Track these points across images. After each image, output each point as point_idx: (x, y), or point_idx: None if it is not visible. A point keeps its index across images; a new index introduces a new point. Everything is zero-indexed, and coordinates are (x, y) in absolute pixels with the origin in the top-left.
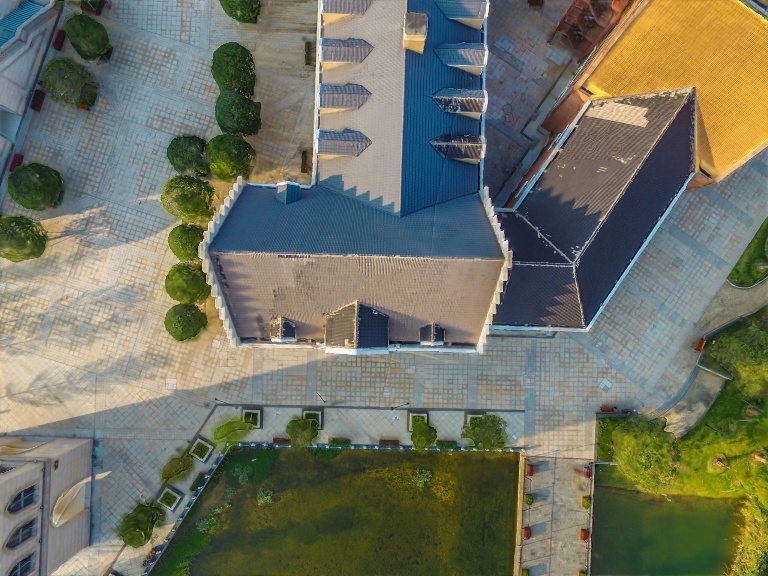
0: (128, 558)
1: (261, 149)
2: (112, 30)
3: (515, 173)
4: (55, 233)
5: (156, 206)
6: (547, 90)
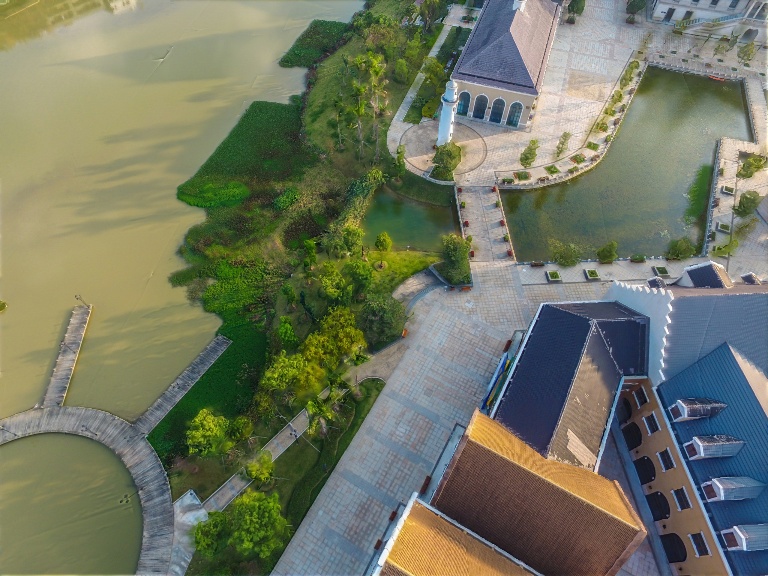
0: (728, 202)
1: None
2: None
3: None
4: None
5: None
6: None
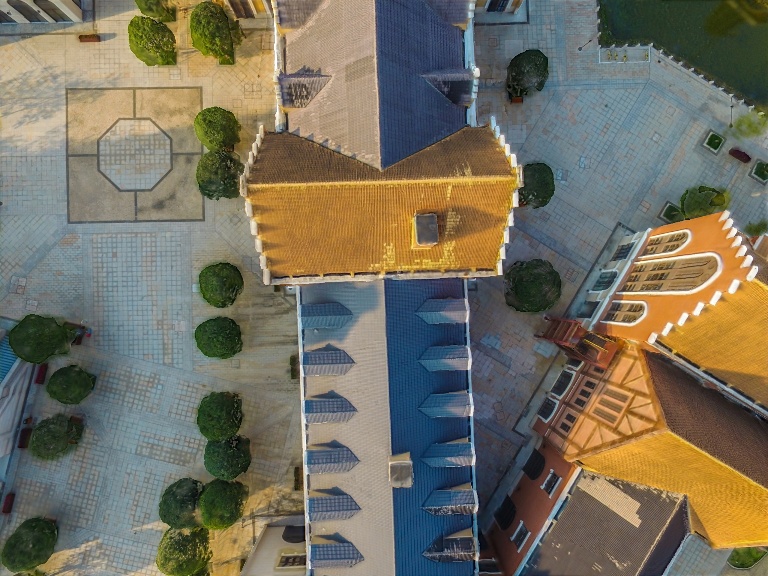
0: None
1: (253, 468)
2: (94, 358)
3: (509, 471)
4: (53, 570)
5: (152, 535)
6: (537, 384)
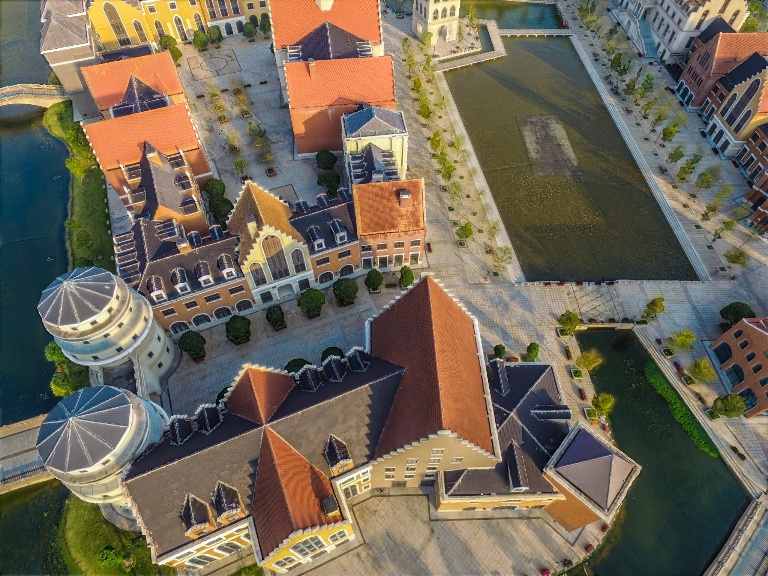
0: None
1: None
2: None
3: None
4: None
5: None
6: None
